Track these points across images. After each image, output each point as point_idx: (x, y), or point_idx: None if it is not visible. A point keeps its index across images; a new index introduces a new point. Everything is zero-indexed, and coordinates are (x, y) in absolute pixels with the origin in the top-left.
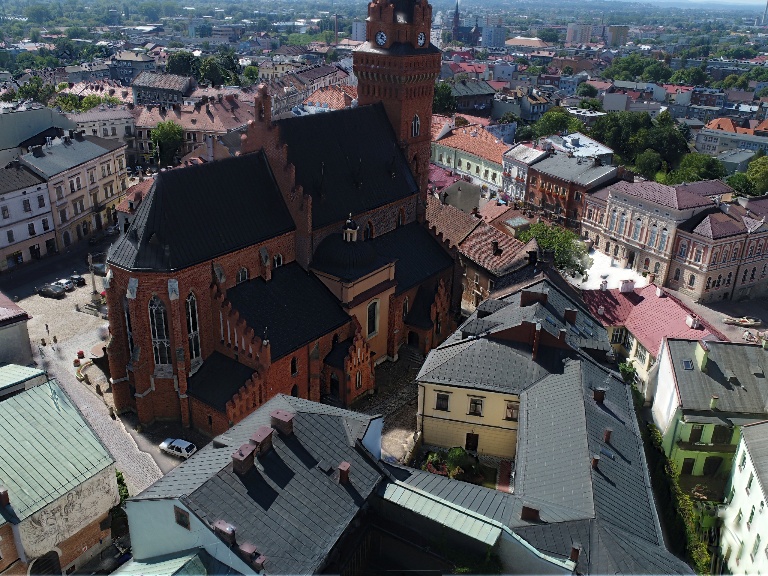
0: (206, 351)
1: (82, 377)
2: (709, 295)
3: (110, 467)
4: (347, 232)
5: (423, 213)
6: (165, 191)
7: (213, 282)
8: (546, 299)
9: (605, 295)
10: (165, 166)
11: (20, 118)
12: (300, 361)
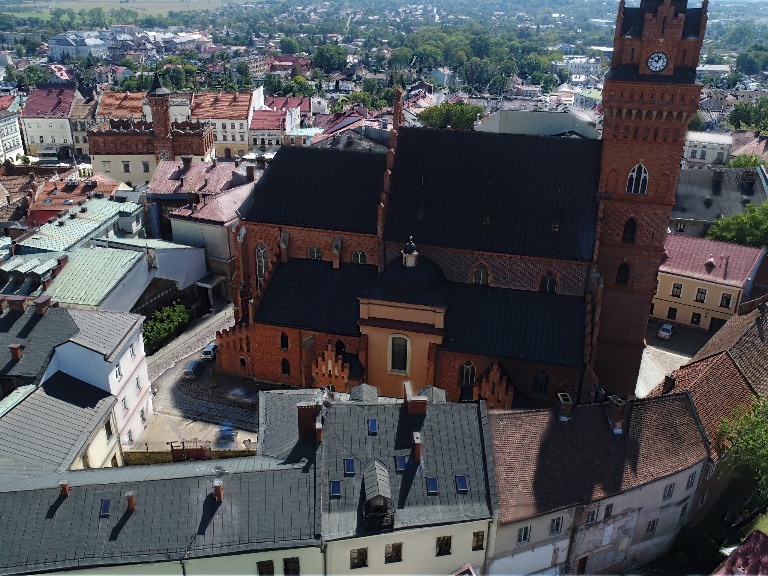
0: None
1: None
2: None
3: (97, 308)
4: None
5: (595, 292)
6: (277, 160)
7: None
8: (408, 406)
9: None
10: None
11: (543, 117)
12: (291, 340)
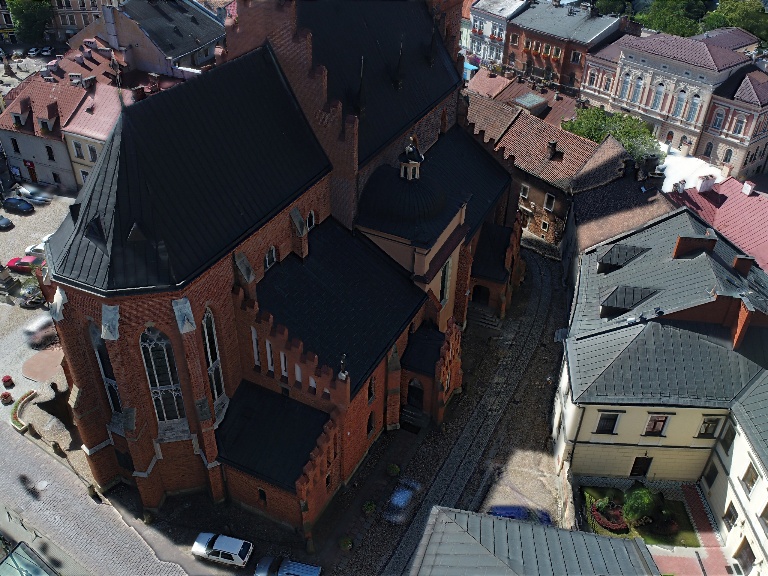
0: (232, 385)
1: (23, 427)
2: (745, 171)
3: None
4: (408, 166)
5: (464, 112)
6: (138, 142)
7: (235, 283)
8: (714, 246)
9: (682, 198)
10: (34, 46)
11: None
12: (377, 379)
